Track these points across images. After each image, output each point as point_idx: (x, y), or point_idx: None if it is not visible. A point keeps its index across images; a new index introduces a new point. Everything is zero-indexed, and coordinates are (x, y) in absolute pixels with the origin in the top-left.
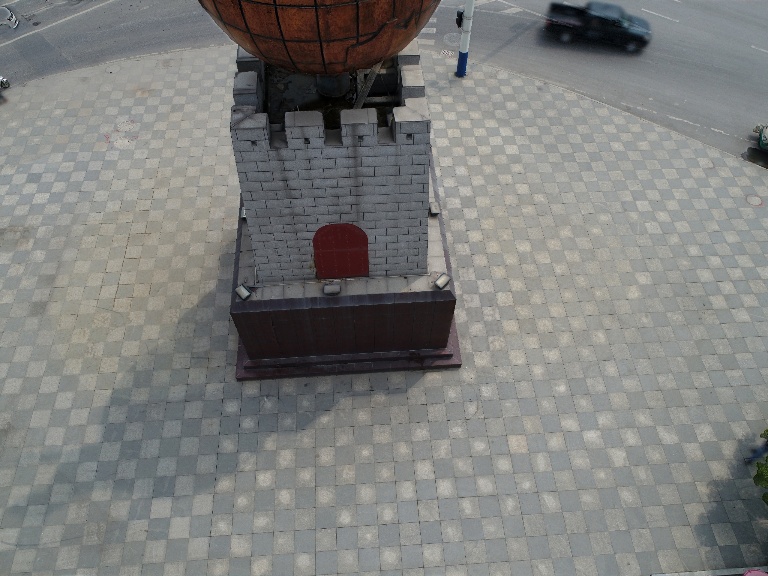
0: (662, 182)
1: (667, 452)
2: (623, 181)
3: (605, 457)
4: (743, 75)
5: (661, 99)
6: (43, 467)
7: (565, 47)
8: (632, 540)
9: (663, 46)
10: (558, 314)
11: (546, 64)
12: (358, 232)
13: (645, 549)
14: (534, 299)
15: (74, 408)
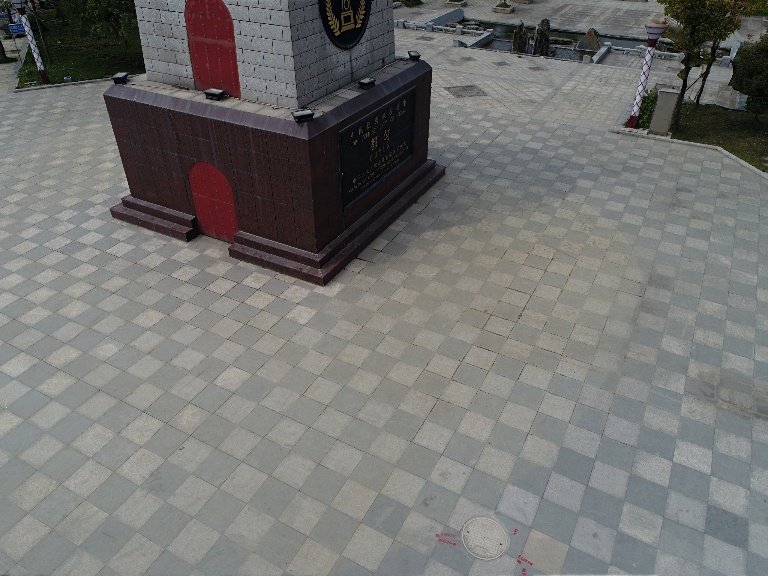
0: None
1: None
2: None
3: None
4: None
5: None
6: (632, 180)
7: None
8: None
9: None
10: None
11: None
12: None
13: None
14: None
15: (605, 199)
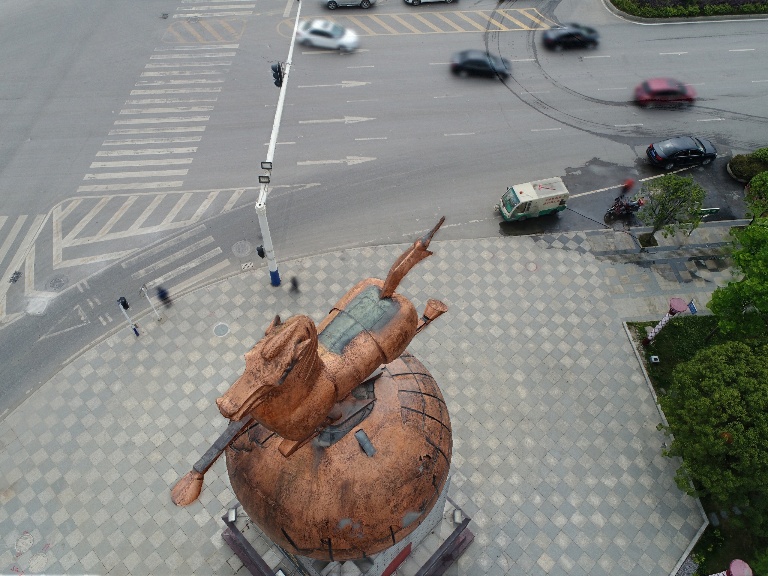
0: (475, 289)
1: (617, 493)
2: (453, 305)
3: (593, 526)
4: (456, 164)
5: (424, 216)
6: None
7: (330, 207)
8: (643, 568)
9: (392, 167)
10: (495, 445)
11: (328, 231)
12: (407, 546)
13: (652, 568)
14: (474, 445)
15: None
